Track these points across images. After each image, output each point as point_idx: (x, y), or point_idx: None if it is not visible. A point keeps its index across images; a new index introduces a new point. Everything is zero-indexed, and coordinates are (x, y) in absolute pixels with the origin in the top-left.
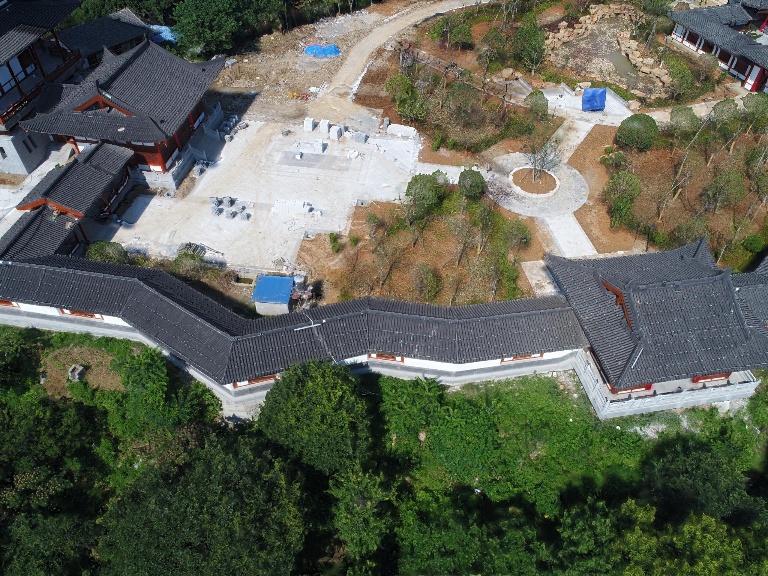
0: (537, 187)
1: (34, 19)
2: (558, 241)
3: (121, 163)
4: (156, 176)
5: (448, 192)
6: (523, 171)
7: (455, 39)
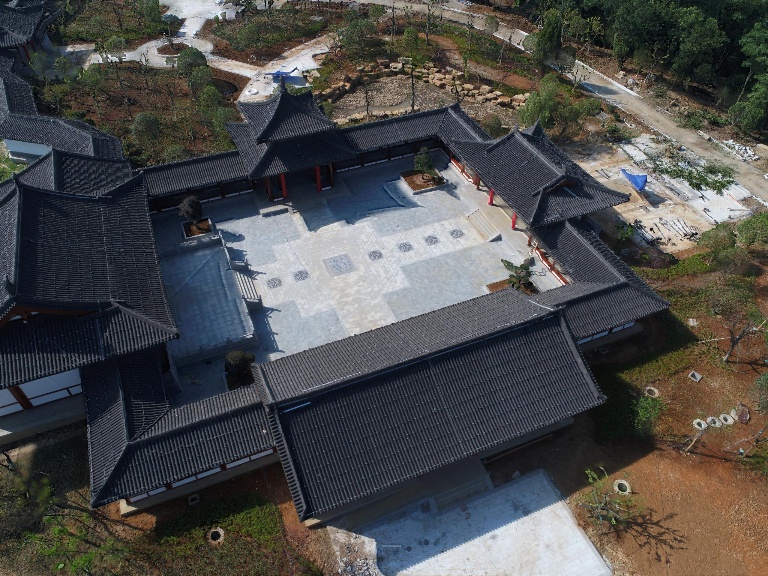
0: (164, 49)
1: None
2: None
3: None
4: None
5: (170, 26)
6: (185, 46)
7: None
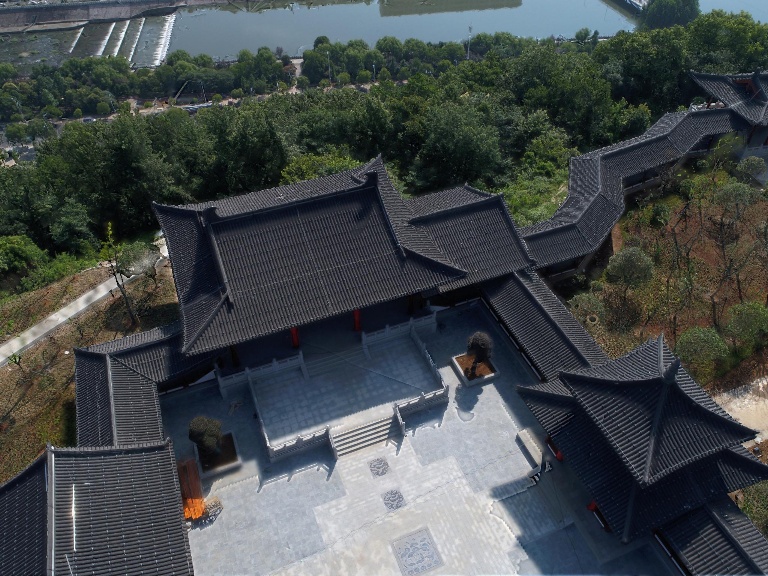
0: None
1: None
2: None
3: None
4: None
5: None
6: None
7: None
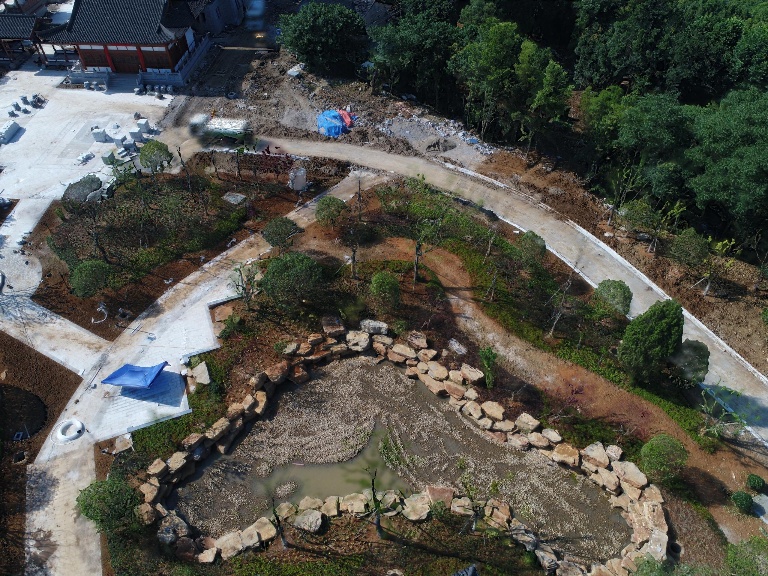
0: None
1: None
2: None
3: None
4: (75, 67)
5: None
6: None
7: None
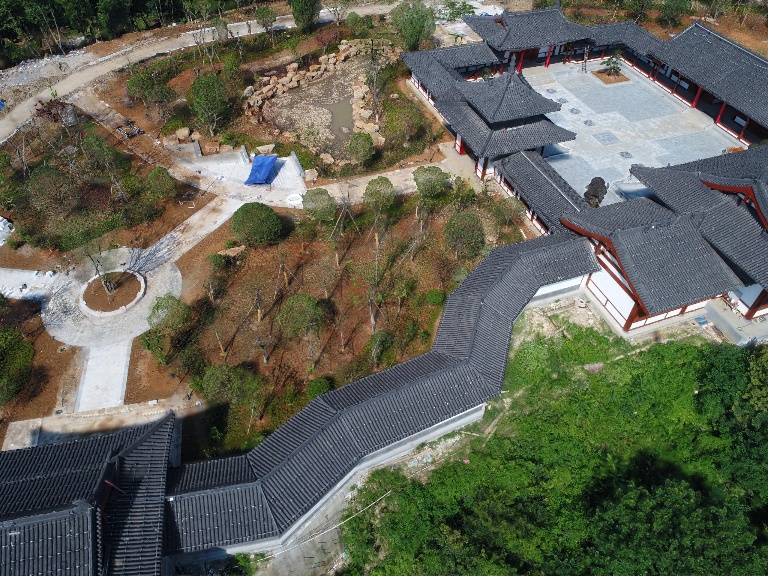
0: (108, 301)
1: None
2: (83, 385)
3: None
4: None
5: None
6: (107, 277)
7: (130, 92)
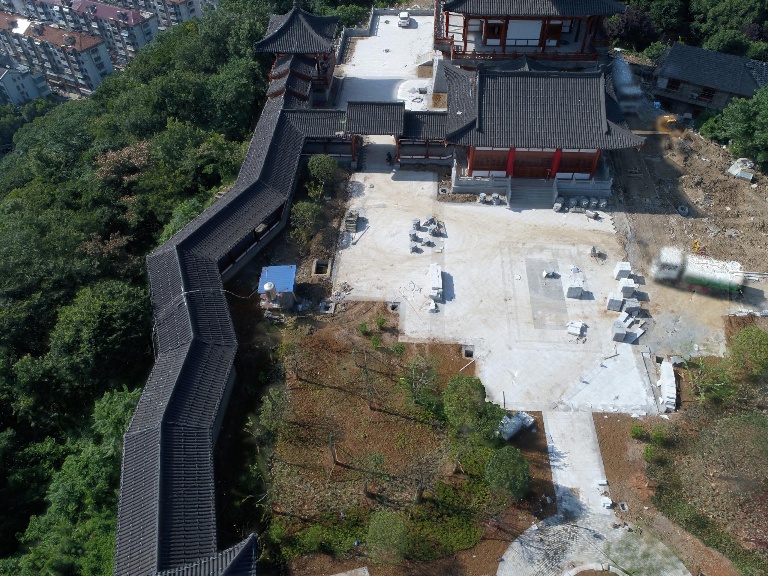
0: None
1: (566, 1)
2: None
3: (438, 136)
4: (454, 170)
5: None
6: None
7: None
